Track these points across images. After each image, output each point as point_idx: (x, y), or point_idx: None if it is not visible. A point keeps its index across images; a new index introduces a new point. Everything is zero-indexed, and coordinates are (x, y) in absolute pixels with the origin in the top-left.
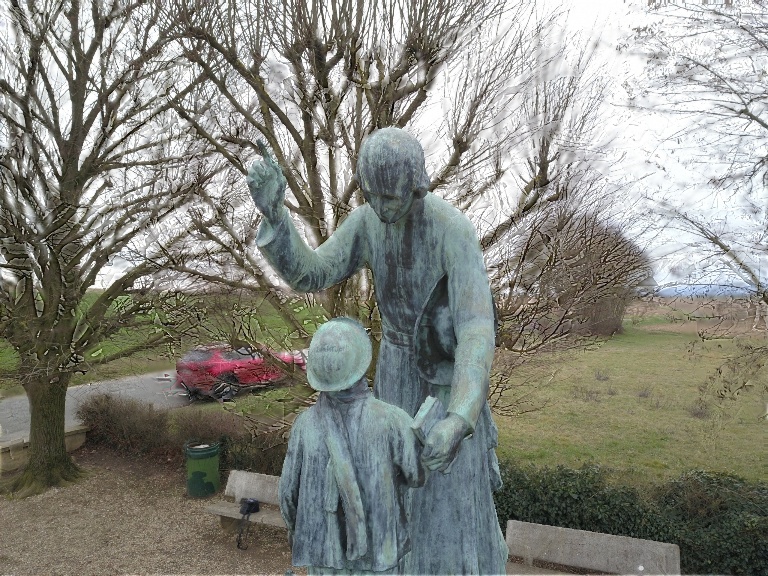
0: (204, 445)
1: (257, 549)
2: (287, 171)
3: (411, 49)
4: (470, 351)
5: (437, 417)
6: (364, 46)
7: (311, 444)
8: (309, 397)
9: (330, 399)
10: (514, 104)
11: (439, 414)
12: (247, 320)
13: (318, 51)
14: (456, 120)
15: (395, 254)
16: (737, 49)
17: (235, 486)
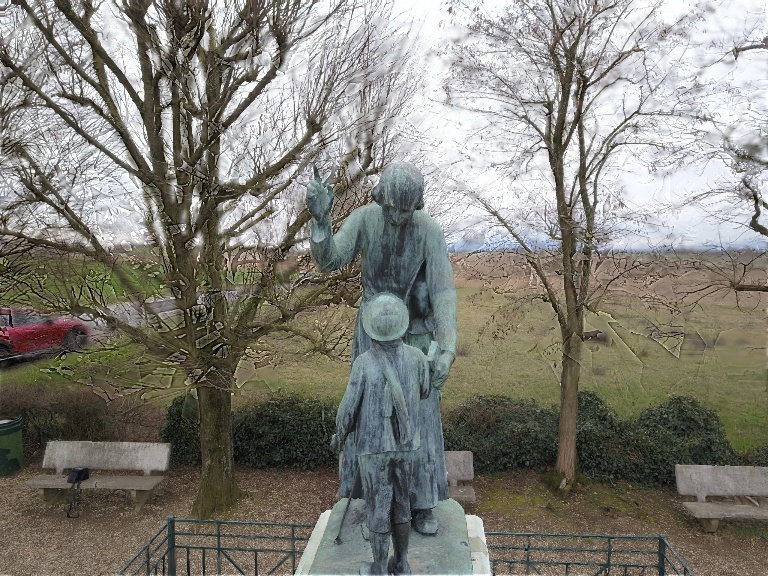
0: (4, 420)
1: (91, 515)
2: (124, 132)
3: (273, 34)
4: (448, 311)
5: (438, 354)
6: (213, 17)
7: (372, 376)
8: (167, 358)
9: (382, 346)
10: (355, 92)
11: (439, 352)
12: (100, 286)
13: (178, 21)
14: (310, 103)
15: (391, 246)
16: (514, 61)
17: (55, 457)
